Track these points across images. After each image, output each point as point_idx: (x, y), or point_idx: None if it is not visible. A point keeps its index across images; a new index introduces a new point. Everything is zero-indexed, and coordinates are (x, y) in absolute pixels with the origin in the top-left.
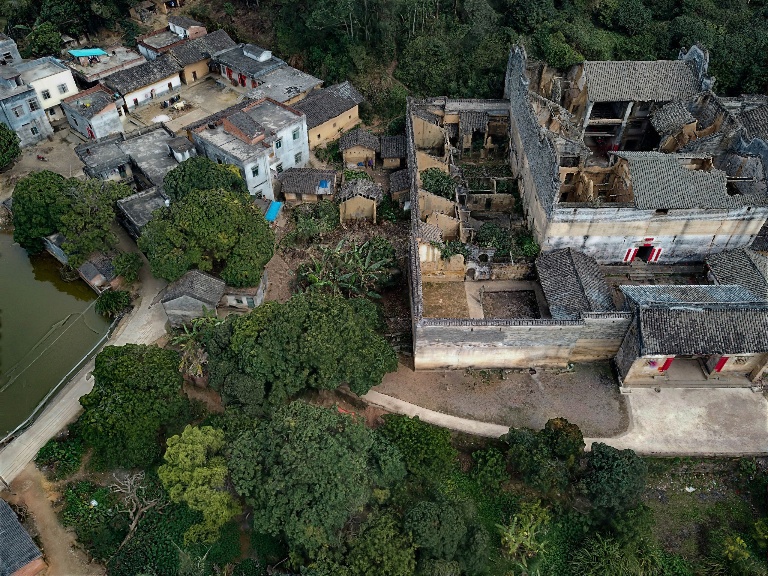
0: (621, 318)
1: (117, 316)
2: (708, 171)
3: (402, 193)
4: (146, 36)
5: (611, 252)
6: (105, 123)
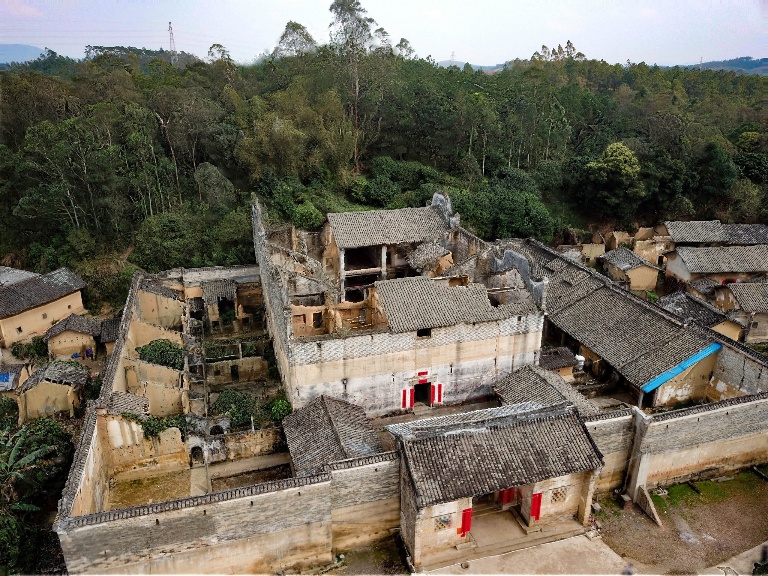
0: (384, 461)
1: None
2: (465, 286)
3: None
4: None
5: (383, 398)
6: None
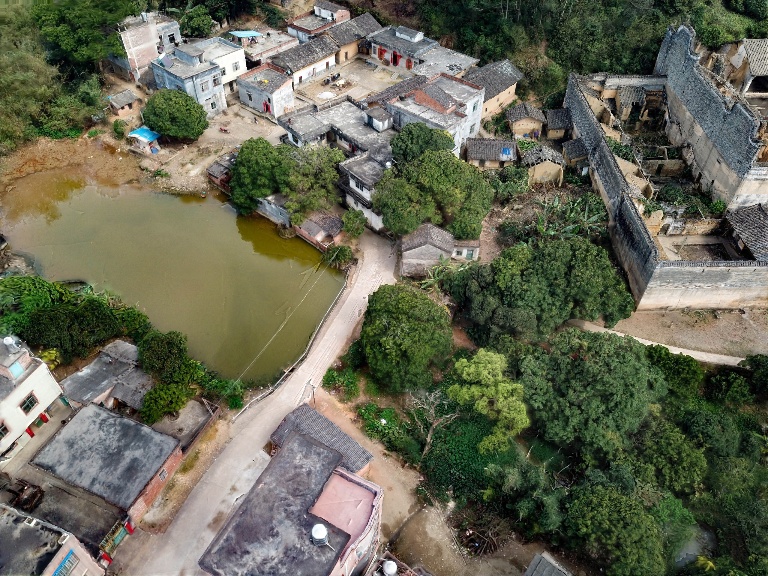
0: None
1: (344, 268)
2: None
3: (579, 160)
4: (294, 19)
5: None
6: (282, 98)
